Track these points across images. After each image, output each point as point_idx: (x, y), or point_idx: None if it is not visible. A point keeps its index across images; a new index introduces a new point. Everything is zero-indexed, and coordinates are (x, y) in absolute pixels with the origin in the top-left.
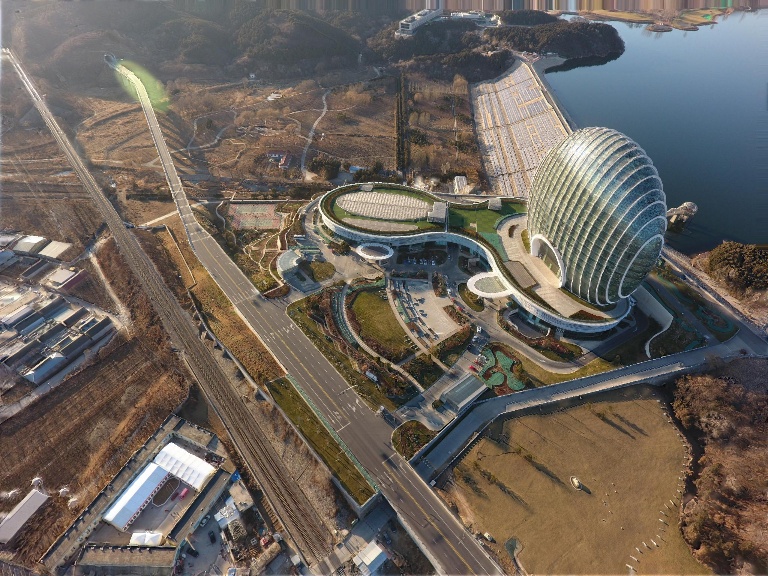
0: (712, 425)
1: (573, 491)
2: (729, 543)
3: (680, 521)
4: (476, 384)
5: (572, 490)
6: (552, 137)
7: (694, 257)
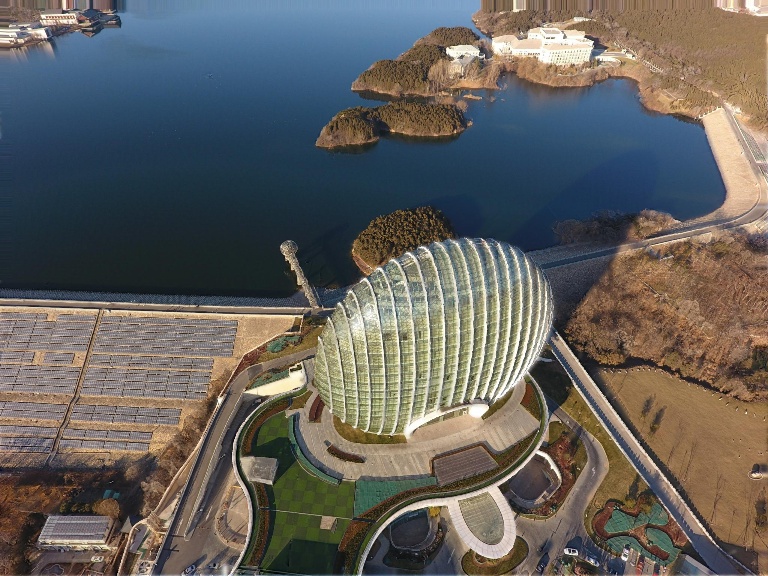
0: (631, 342)
1: (767, 480)
2: (758, 373)
3: (735, 399)
4: (693, 572)
5: (767, 481)
6: (8, 330)
7: (365, 275)
